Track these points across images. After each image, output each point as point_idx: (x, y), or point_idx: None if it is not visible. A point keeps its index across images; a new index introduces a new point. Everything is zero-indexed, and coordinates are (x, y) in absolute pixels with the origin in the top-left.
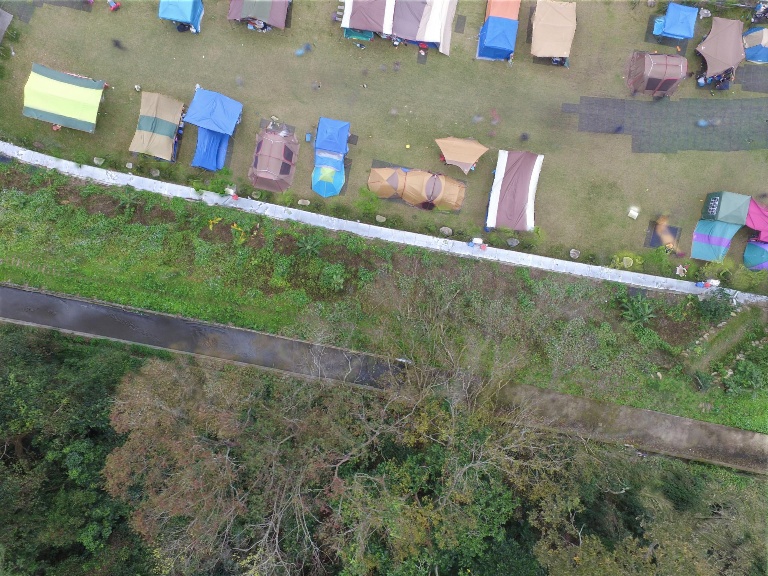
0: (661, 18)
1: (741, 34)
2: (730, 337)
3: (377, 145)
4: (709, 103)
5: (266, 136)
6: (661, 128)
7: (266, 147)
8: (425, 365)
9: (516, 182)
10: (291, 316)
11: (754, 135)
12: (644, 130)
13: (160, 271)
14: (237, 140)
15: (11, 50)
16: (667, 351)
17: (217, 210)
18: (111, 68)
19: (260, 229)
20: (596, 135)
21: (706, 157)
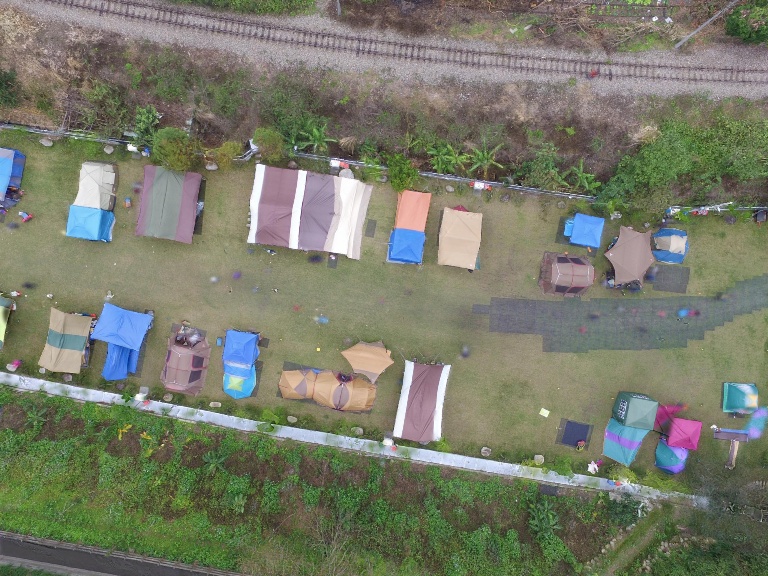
0: (572, 219)
1: (649, 241)
2: (638, 540)
3: (288, 347)
4: (620, 303)
5: (174, 348)
6: (572, 328)
7: (174, 360)
8: None
9: (423, 391)
10: (191, 541)
11: (665, 334)
12: (555, 330)
13: (61, 499)
14: (149, 344)
15: None
16: (570, 565)
17: (128, 415)
18: (24, 276)
19: (169, 437)
20: (507, 335)
21: (617, 356)
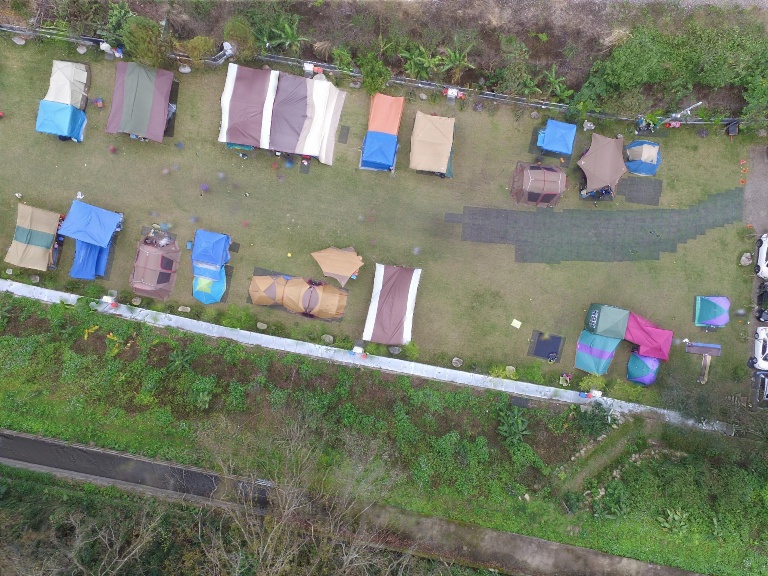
0: None
1: (621, 150)
2: (609, 451)
3: (259, 253)
4: (593, 214)
5: (142, 247)
6: (544, 238)
7: (142, 258)
8: (288, 486)
9: (393, 295)
10: (154, 435)
11: (638, 246)
12: (527, 240)
13: (22, 390)
14: (118, 247)
15: None
16: (539, 470)
17: (95, 317)
18: None
19: (136, 338)
20: (479, 245)
21: (590, 267)
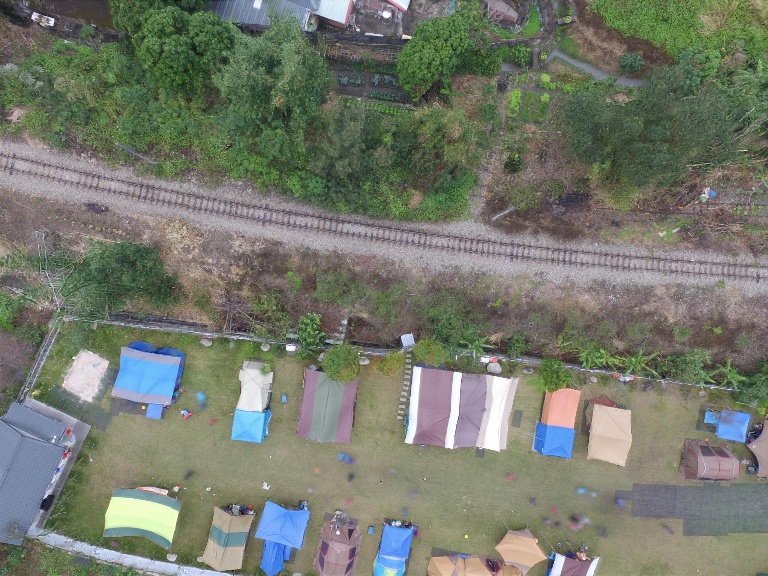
0: (712, 407)
1: None
2: None
3: (436, 534)
4: (759, 487)
5: (332, 544)
6: (712, 512)
7: (332, 555)
8: None
9: None
10: None
11: None
12: (695, 514)
13: None
14: None
15: (89, 457)
16: None
17: None
18: (183, 470)
19: None
20: (648, 520)
21: (756, 539)
